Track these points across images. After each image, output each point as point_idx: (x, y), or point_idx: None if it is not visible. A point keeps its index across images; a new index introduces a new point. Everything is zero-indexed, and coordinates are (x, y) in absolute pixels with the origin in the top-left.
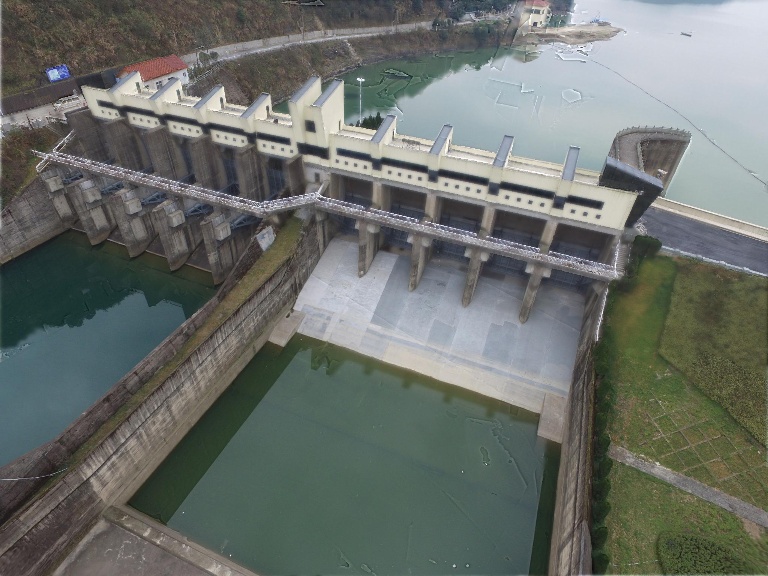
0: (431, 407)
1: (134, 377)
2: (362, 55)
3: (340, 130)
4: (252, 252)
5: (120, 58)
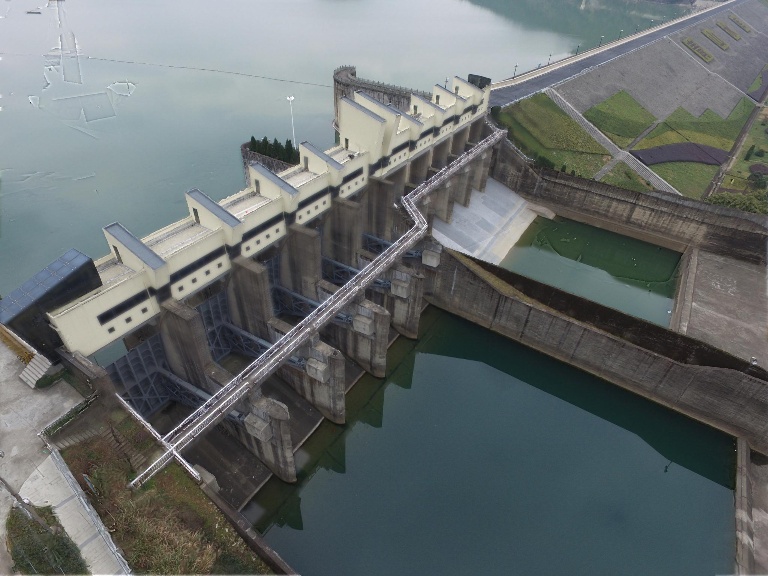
0: None
1: None
2: None
3: None
4: None
5: None
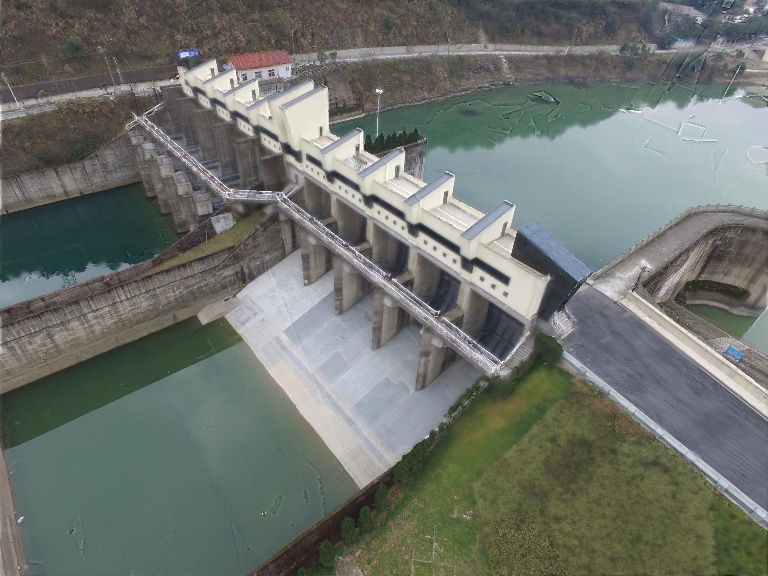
0: (276, 435)
1: (40, 302)
2: (517, 73)
3: (322, 136)
4: (203, 231)
5: (250, 49)
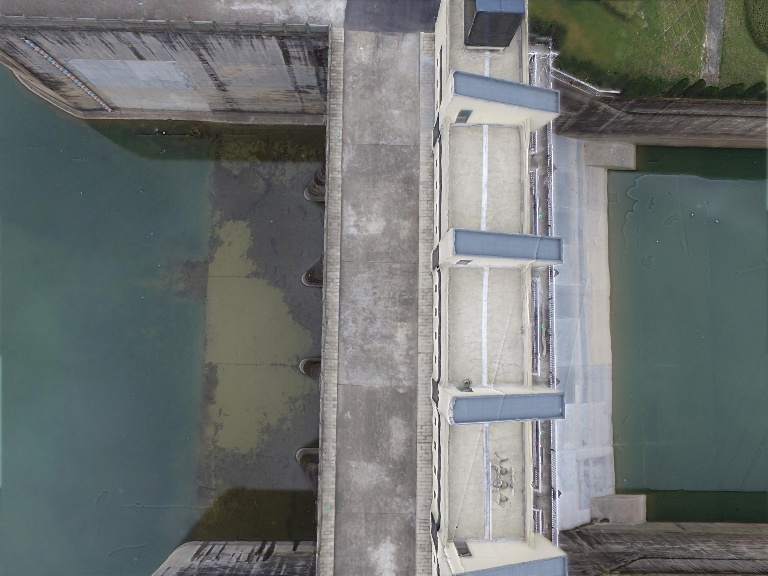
0: (633, 289)
1: None
2: None
3: None
4: None
5: None
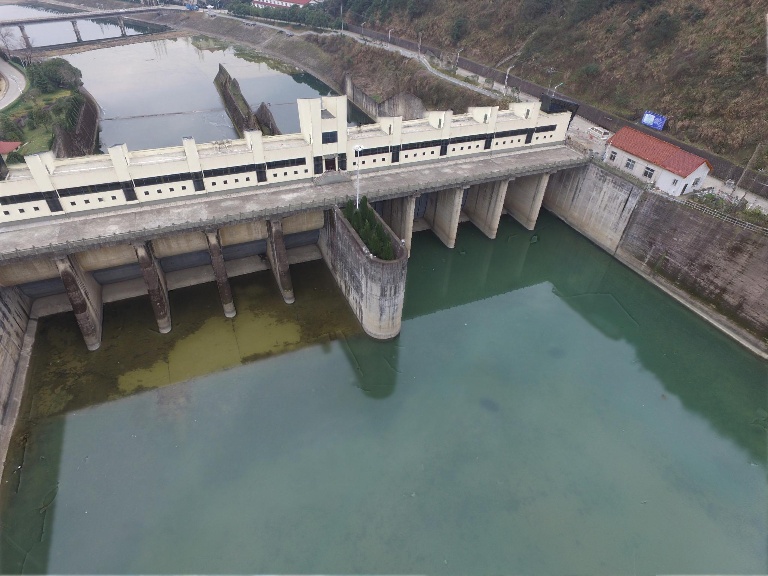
0: None
1: None
2: None
3: None
4: None
5: (741, 154)
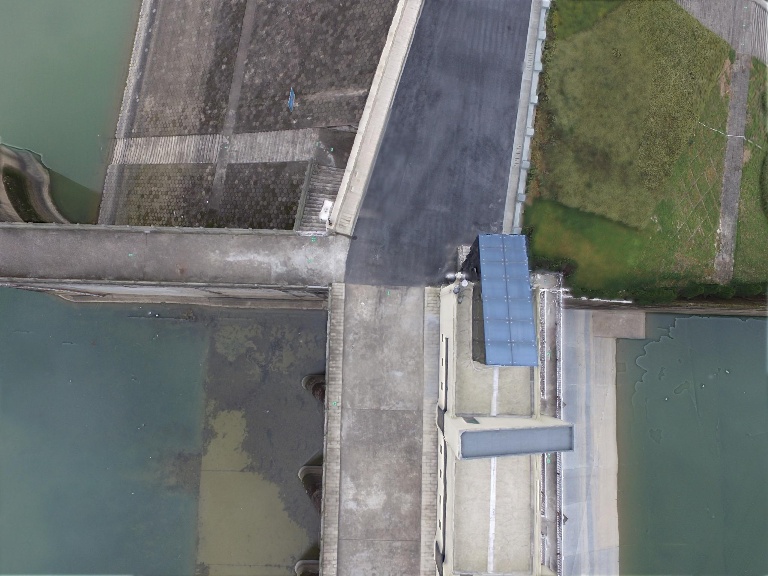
0: (641, 459)
1: None
2: None
3: None
4: None
5: None
